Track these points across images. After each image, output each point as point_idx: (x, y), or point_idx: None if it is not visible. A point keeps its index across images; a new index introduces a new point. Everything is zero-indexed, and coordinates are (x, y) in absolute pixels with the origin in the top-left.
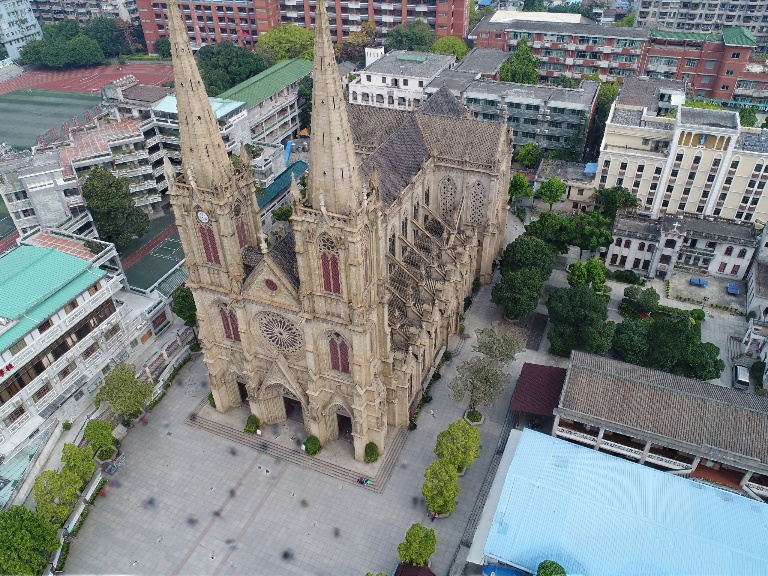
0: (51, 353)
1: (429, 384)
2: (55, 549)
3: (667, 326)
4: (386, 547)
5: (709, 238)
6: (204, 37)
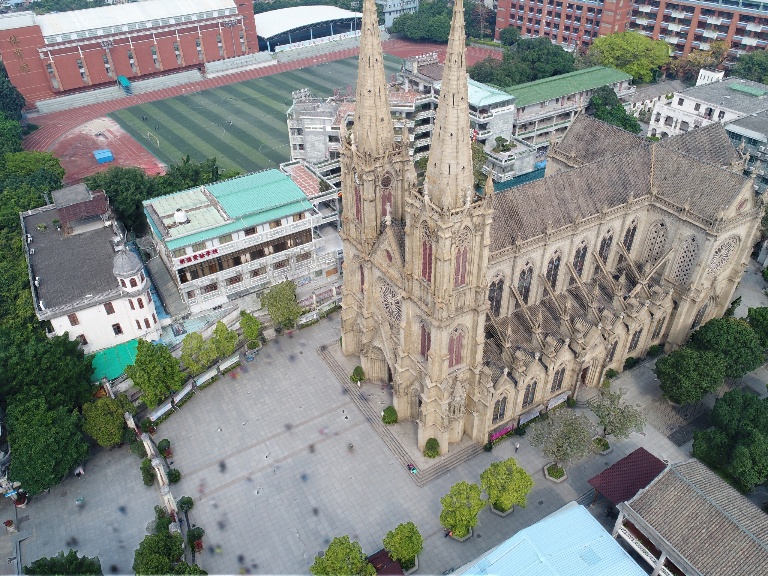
0: (249, 254)
1: (533, 419)
2: (176, 389)
3: None
4: None
5: None
6: (547, 32)
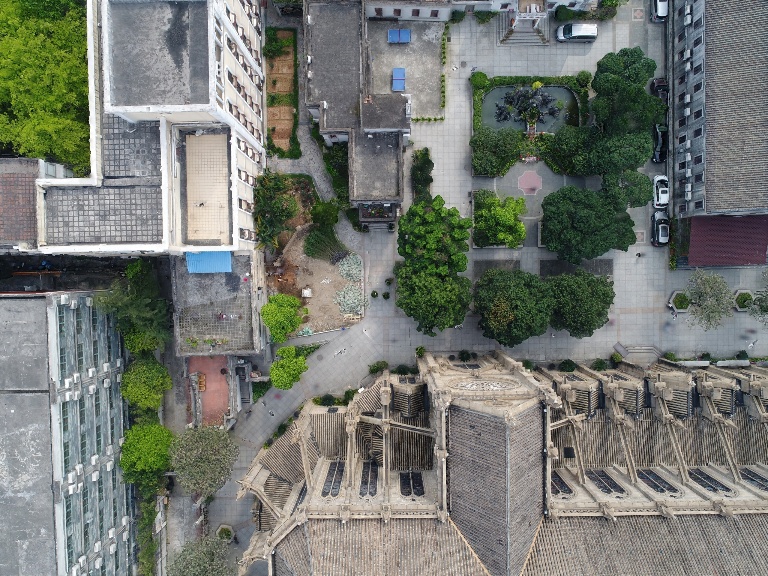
0: None
1: None
2: None
3: None
4: None
5: (366, 63)
6: None
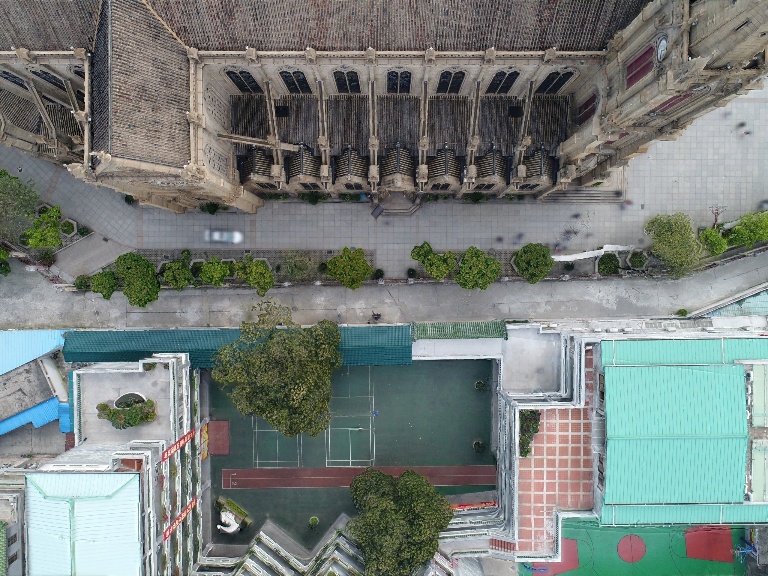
0: None
1: None
2: None
3: None
4: None
5: None
6: None
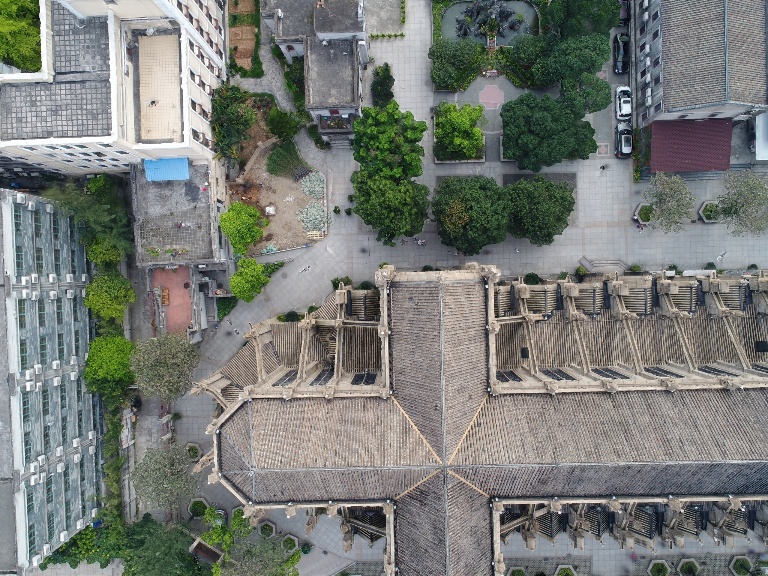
0: None
1: None
2: None
3: None
4: None
5: None
6: None
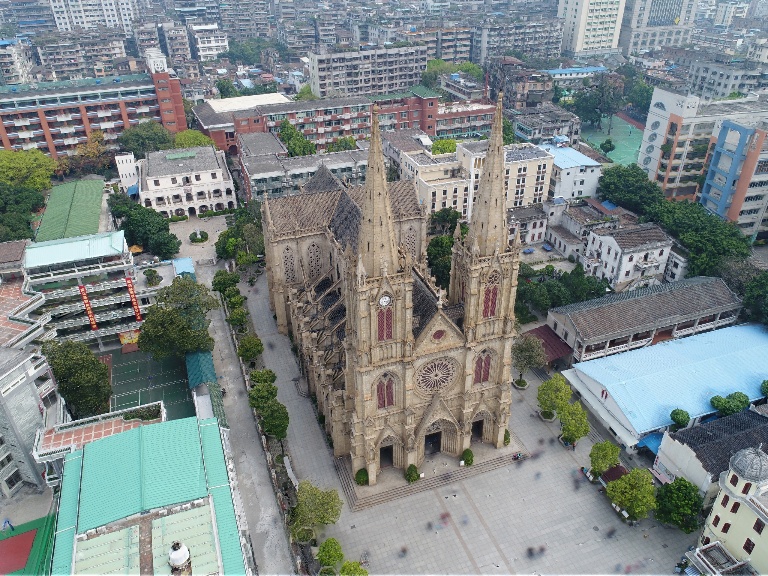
0: None
1: None
2: None
3: (572, 274)
4: (572, 480)
5: (523, 221)
6: None
